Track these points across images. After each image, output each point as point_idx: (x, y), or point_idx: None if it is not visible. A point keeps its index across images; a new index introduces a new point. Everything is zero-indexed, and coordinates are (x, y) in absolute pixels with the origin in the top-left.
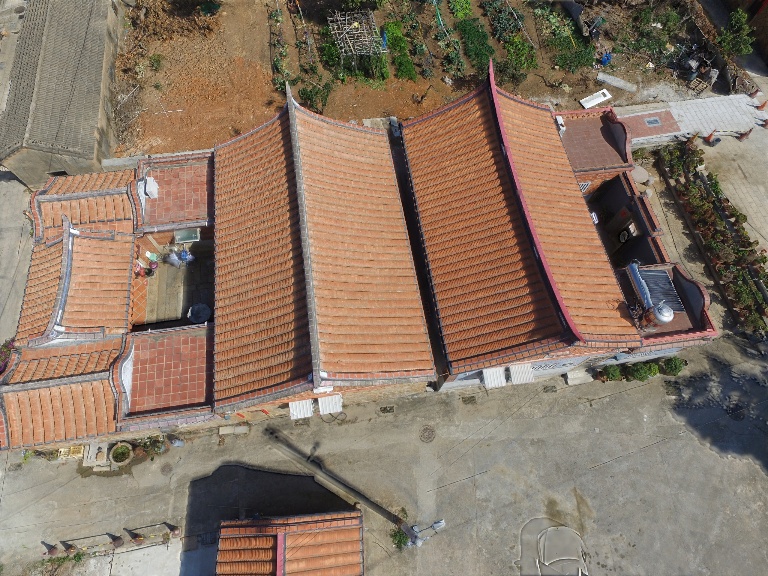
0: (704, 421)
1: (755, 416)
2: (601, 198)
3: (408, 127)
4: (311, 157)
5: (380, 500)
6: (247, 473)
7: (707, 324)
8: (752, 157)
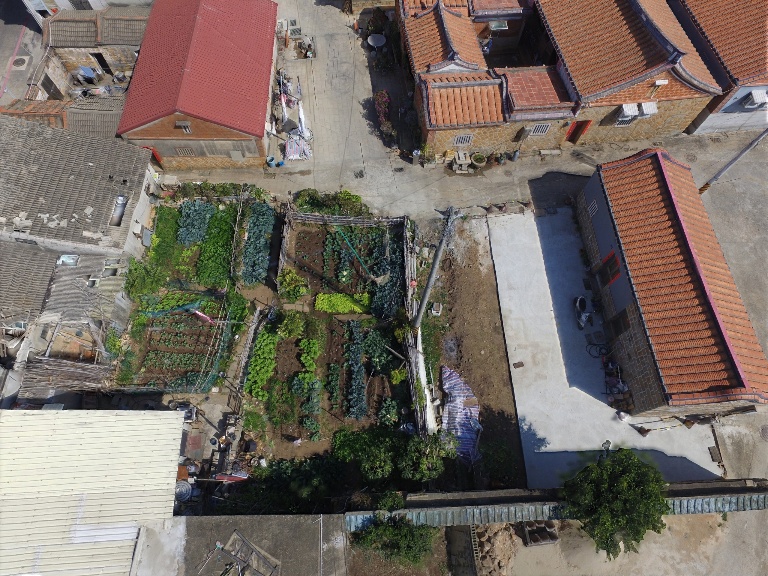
0: None
1: None
2: None
3: None
4: None
5: None
6: (568, 176)
7: None
8: None
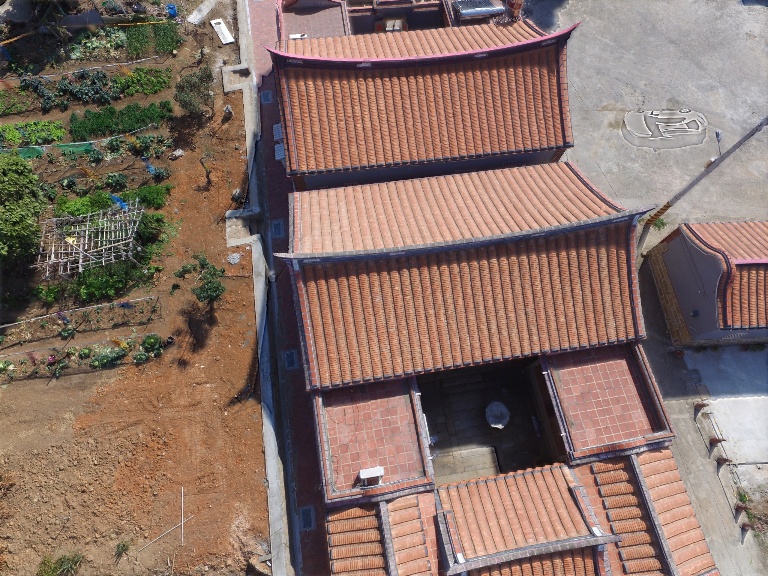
0: None
1: (528, 3)
2: None
3: (298, 164)
4: (363, 247)
5: None
6: None
7: None
8: None
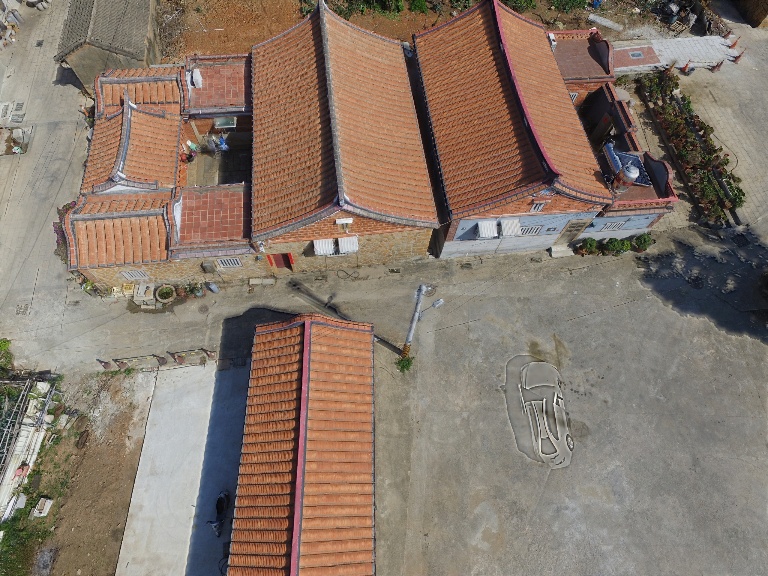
0: (668, 288)
1: (712, 286)
2: (587, 113)
3: (420, 37)
4: (337, 50)
5: (387, 337)
6: (273, 314)
7: (670, 194)
8: (722, 85)
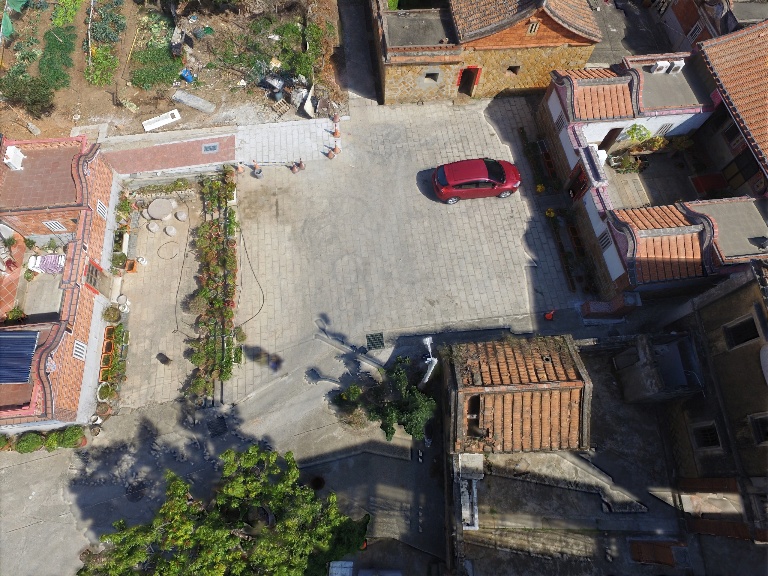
0: (95, 501)
1: (154, 497)
2: None
3: None
4: None
5: None
6: None
7: None
8: (297, 191)
